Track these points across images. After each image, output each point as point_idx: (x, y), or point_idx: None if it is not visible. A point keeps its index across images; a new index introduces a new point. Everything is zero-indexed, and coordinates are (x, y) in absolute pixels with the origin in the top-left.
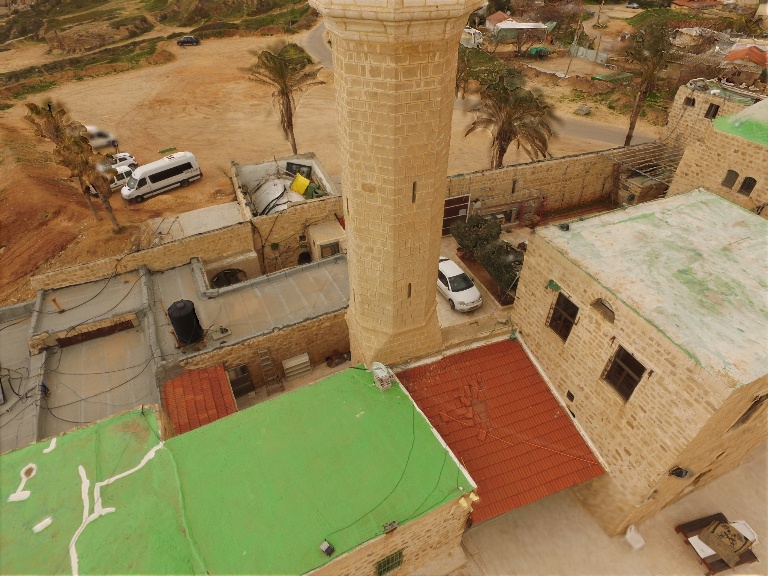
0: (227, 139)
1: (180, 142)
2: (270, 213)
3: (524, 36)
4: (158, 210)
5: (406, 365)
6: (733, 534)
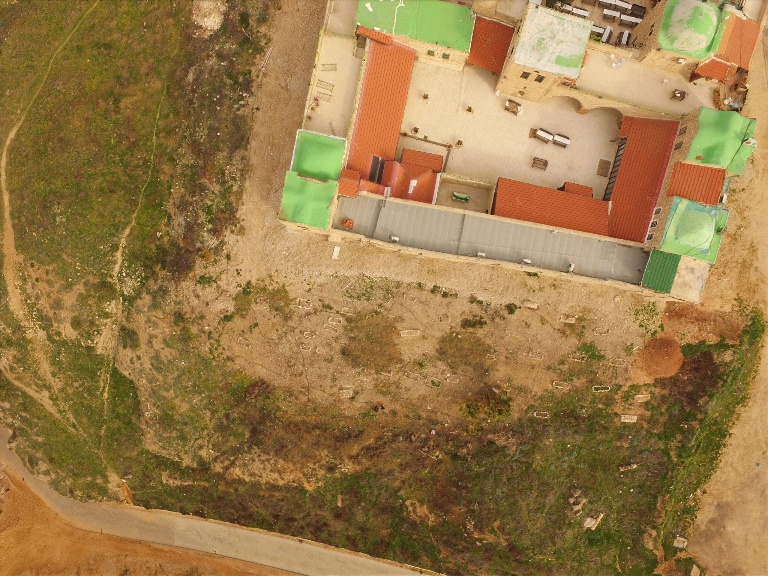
0: None
1: None
2: None
3: None
4: None
5: (481, 15)
6: (516, 107)
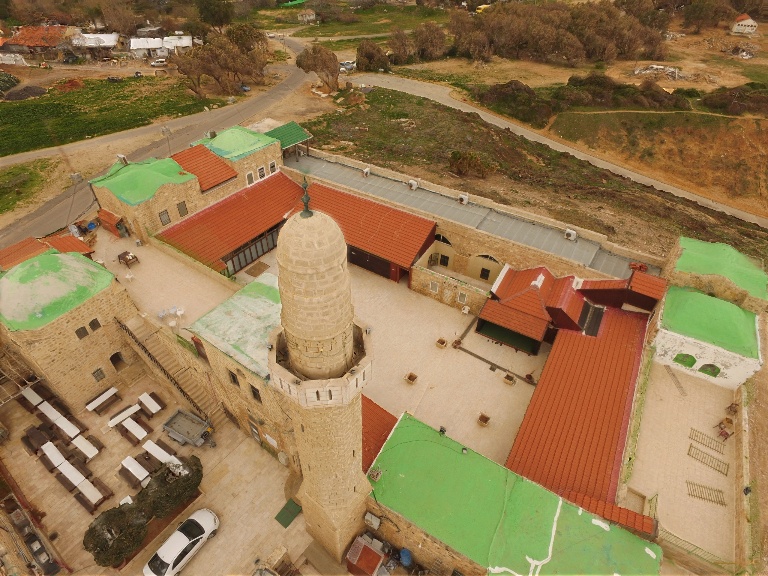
0: None
1: None
2: None
3: None
4: None
5: None
6: None
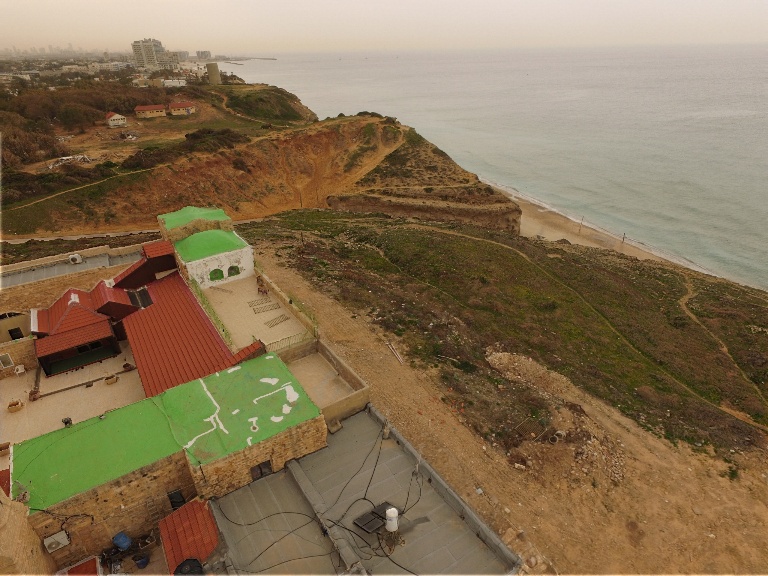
0: None
1: None
2: None
3: None
4: None
5: None
6: None
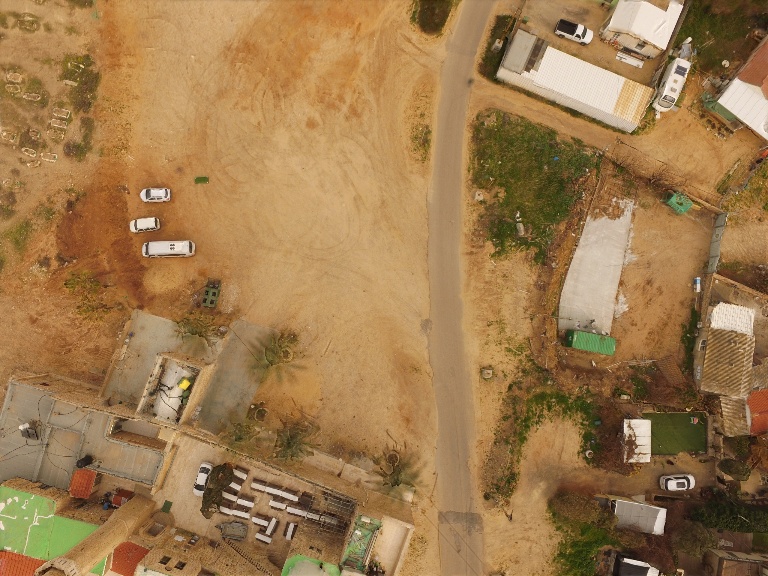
0: (247, 191)
1: (216, 170)
2: (161, 393)
3: (740, 128)
4: (143, 303)
5: None
6: None
